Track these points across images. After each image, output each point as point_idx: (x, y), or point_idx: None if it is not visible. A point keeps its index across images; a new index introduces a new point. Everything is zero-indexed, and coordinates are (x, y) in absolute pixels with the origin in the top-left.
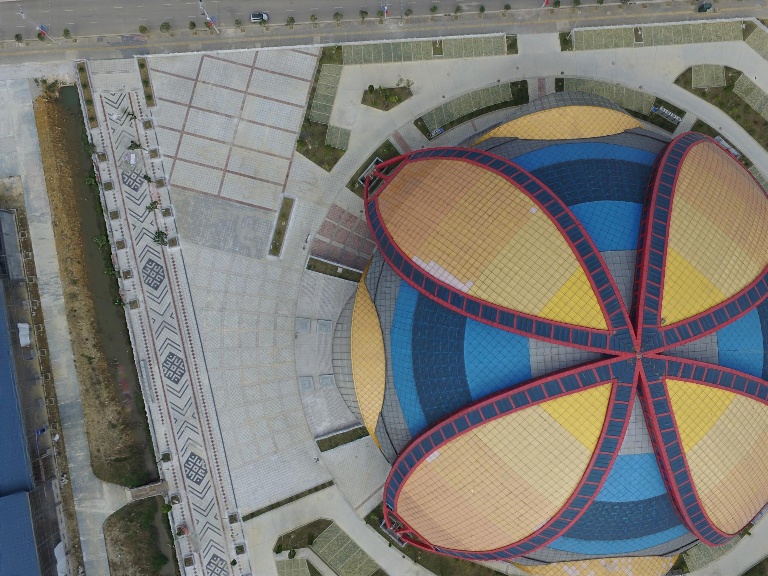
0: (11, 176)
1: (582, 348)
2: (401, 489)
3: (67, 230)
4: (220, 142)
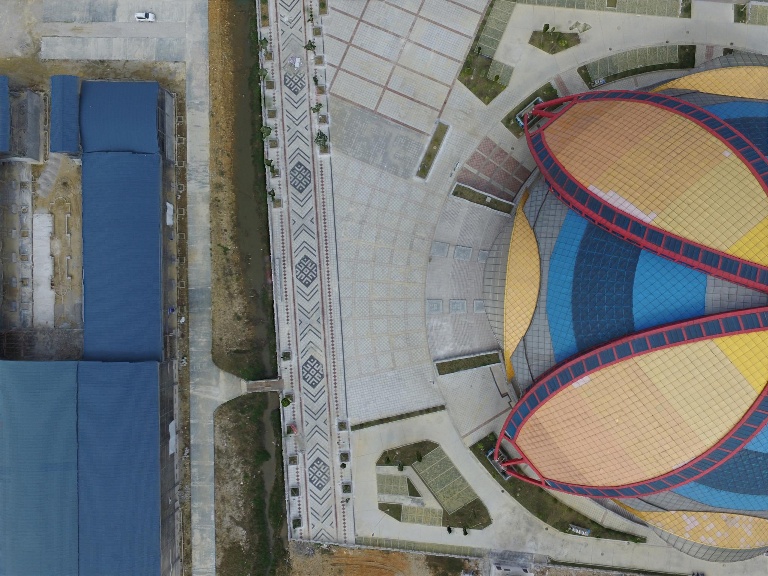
0: (176, 61)
1: (767, 289)
2: (532, 415)
3: (222, 122)
4: (385, 59)
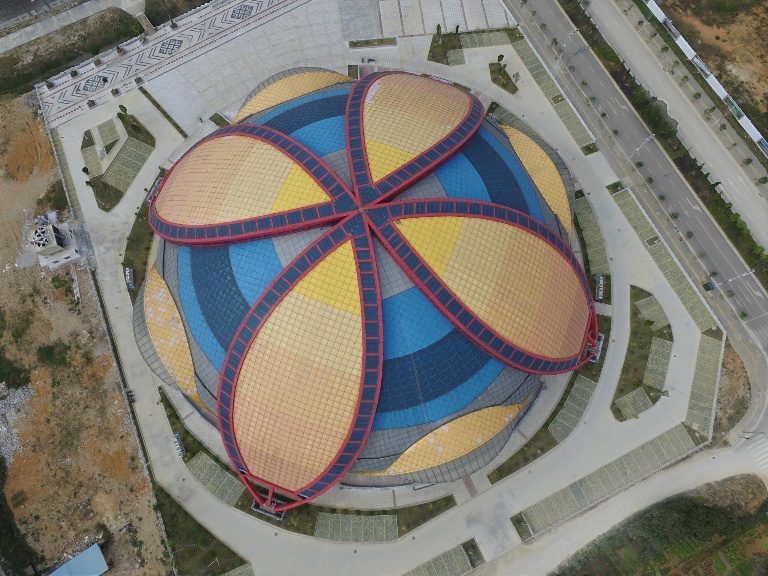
0: None
1: (351, 170)
2: None
3: None
4: None
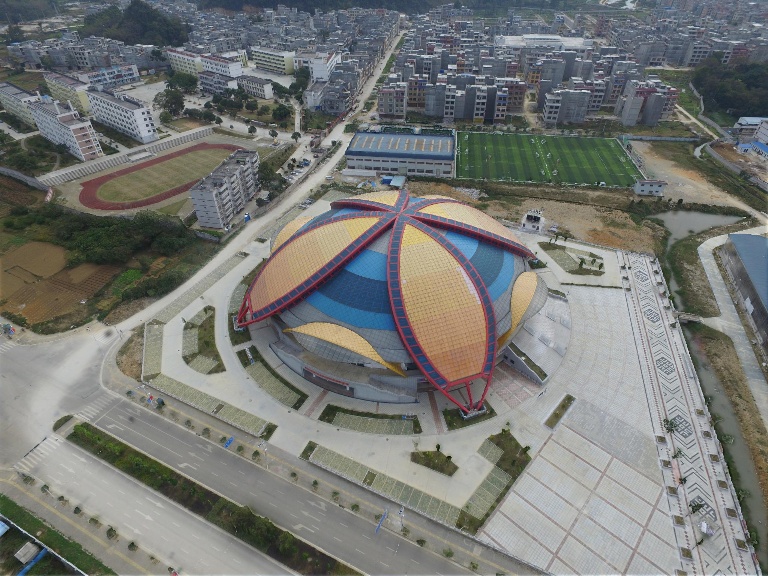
0: None
1: (422, 223)
2: None
3: None
4: (605, 500)
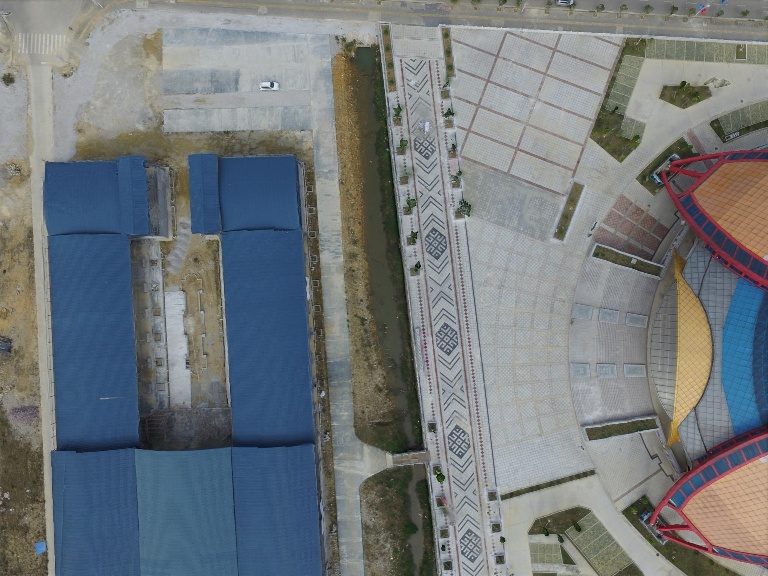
0: (303, 129)
1: None
2: (707, 486)
3: (353, 190)
4: (515, 120)
